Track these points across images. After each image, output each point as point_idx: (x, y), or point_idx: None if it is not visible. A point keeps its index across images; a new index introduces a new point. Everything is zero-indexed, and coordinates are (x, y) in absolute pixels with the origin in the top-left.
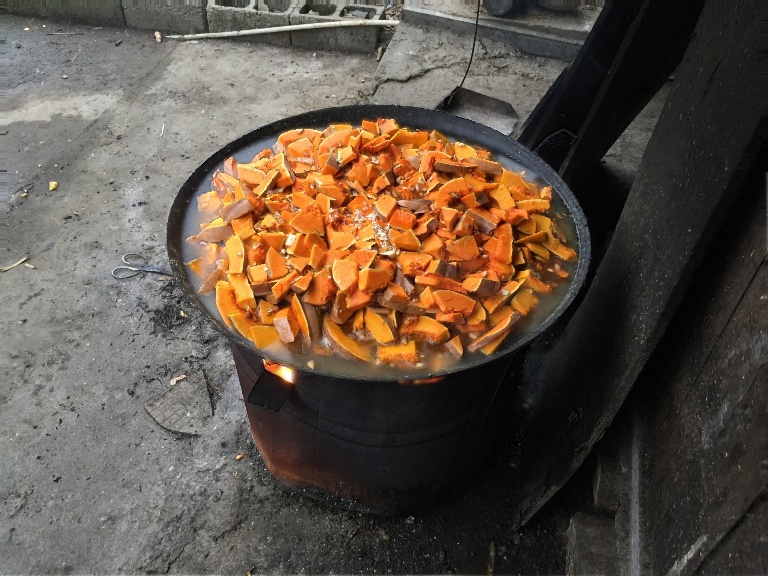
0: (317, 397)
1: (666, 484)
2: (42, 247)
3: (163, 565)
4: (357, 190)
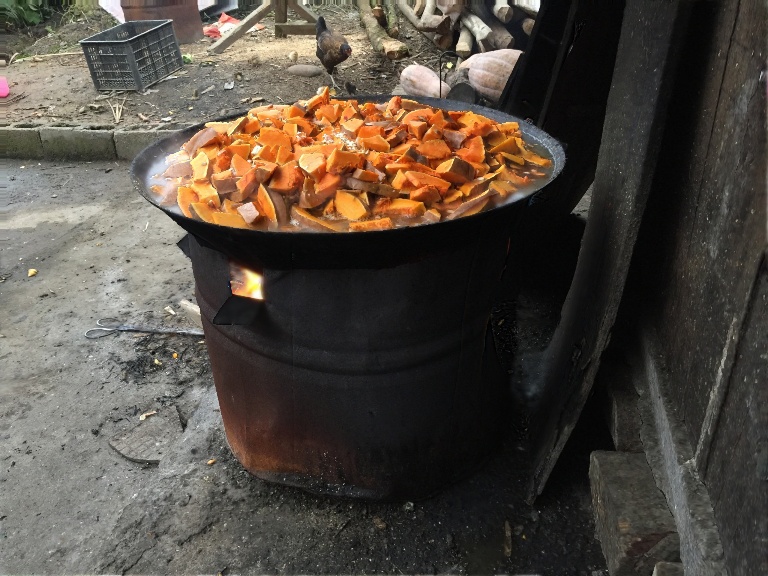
0: (289, 308)
1: (686, 349)
2: (14, 320)
3: (116, 572)
4: (325, 125)
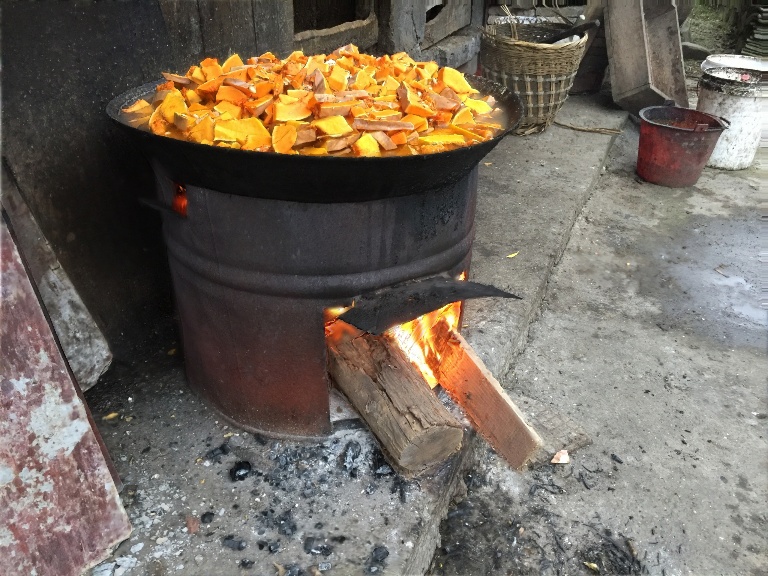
0: None
1: None
2: None
3: None
4: None
